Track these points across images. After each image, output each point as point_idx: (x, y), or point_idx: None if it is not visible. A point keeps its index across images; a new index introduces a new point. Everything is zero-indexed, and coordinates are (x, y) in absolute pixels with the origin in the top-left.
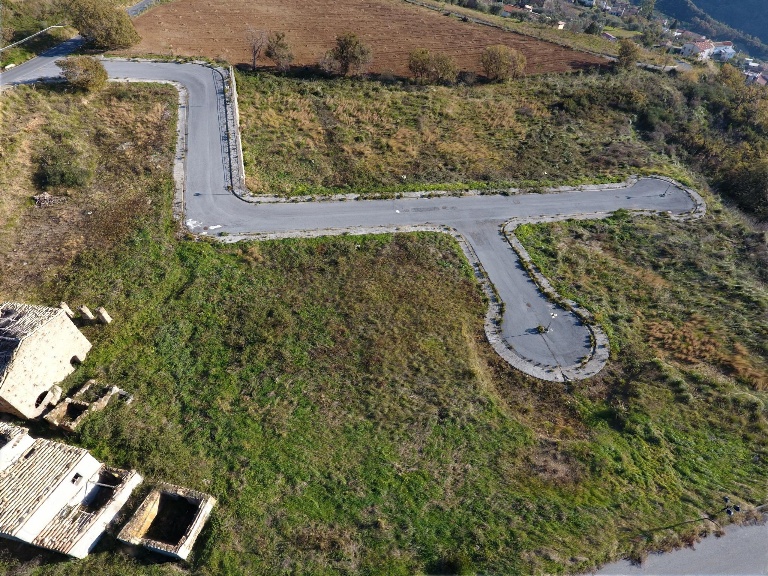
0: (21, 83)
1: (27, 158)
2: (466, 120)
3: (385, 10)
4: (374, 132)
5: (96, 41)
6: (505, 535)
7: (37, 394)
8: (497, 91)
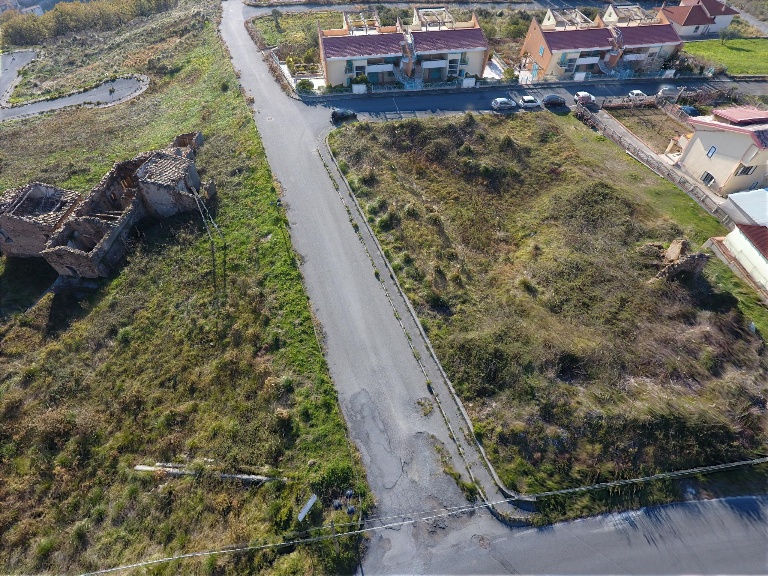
0: None
1: None
2: None
3: None
4: None
5: None
6: (216, 83)
7: None
8: None
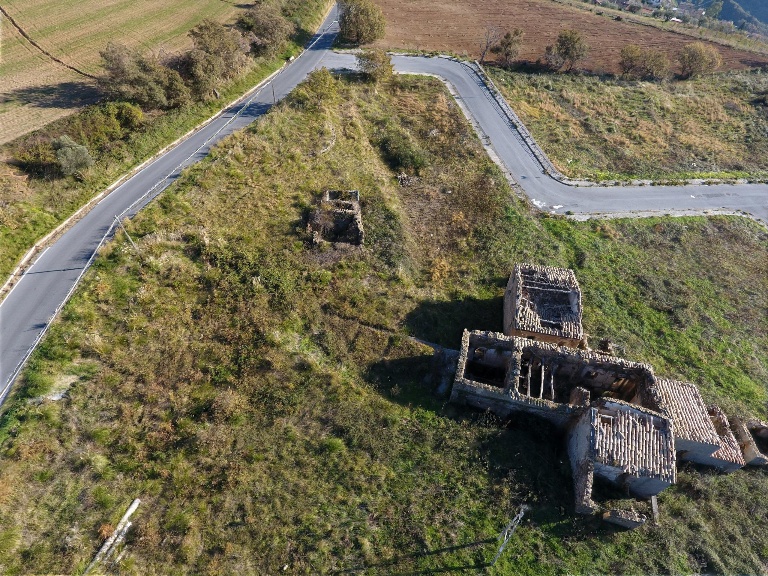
0: None
1: (368, 142)
2: (685, 114)
3: (545, 9)
4: (619, 124)
5: (345, 36)
6: None
7: None
8: (695, 87)
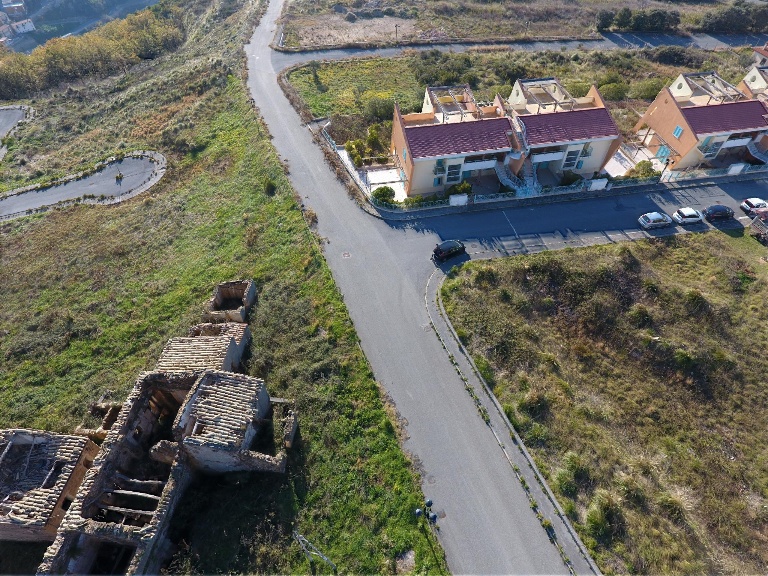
0: None
1: None
2: None
3: None
4: None
5: None
6: (256, 177)
7: None
8: None
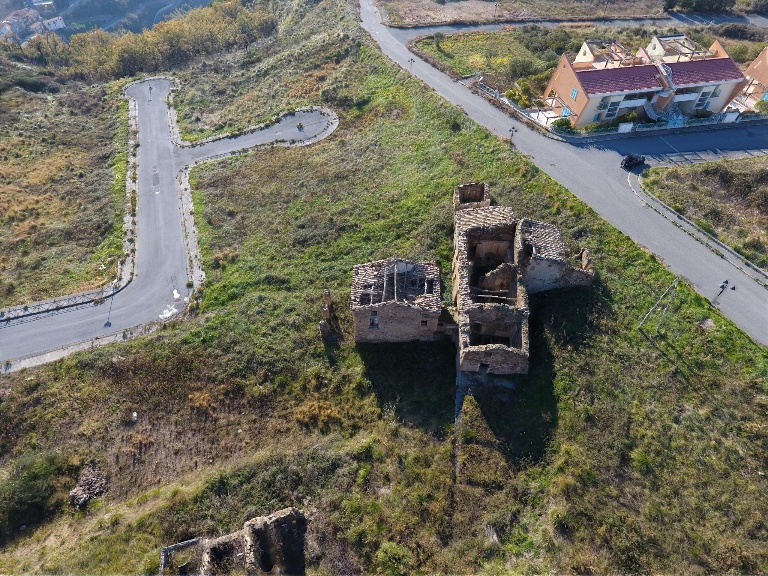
0: None
1: None
2: None
3: None
4: None
5: None
6: (434, 119)
7: None
8: None
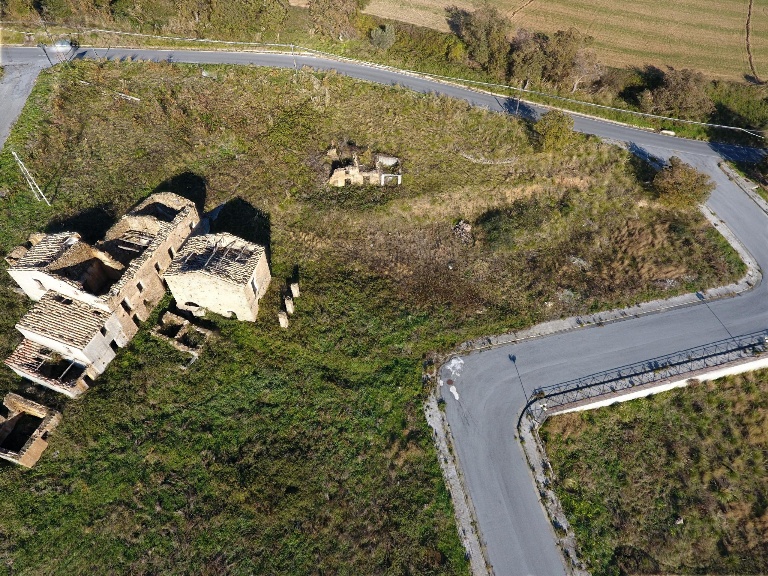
0: (634, 149)
1: (517, 197)
2: None
3: None
4: None
5: None
6: None
7: (191, 300)
8: None
